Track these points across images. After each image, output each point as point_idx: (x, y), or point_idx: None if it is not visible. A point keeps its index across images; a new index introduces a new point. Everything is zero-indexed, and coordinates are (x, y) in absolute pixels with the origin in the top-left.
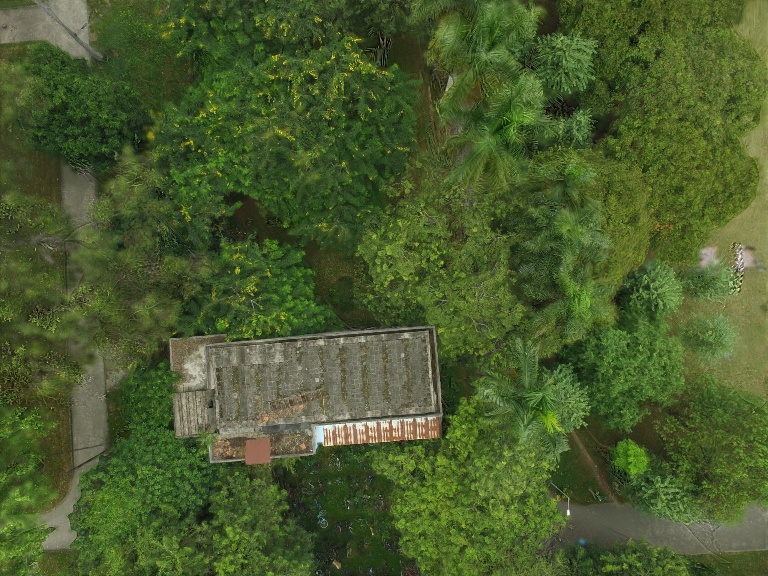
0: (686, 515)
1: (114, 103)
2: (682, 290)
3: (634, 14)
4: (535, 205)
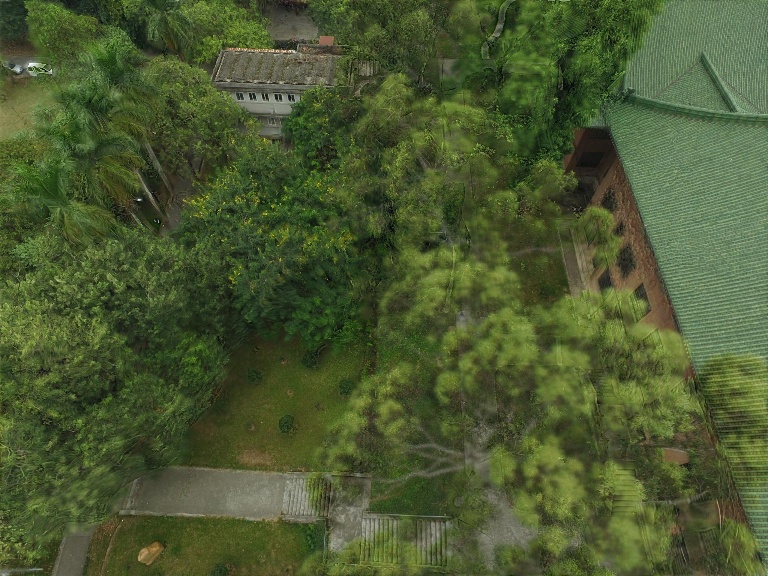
0: (112, 29)
1: None
2: None
3: None
4: None
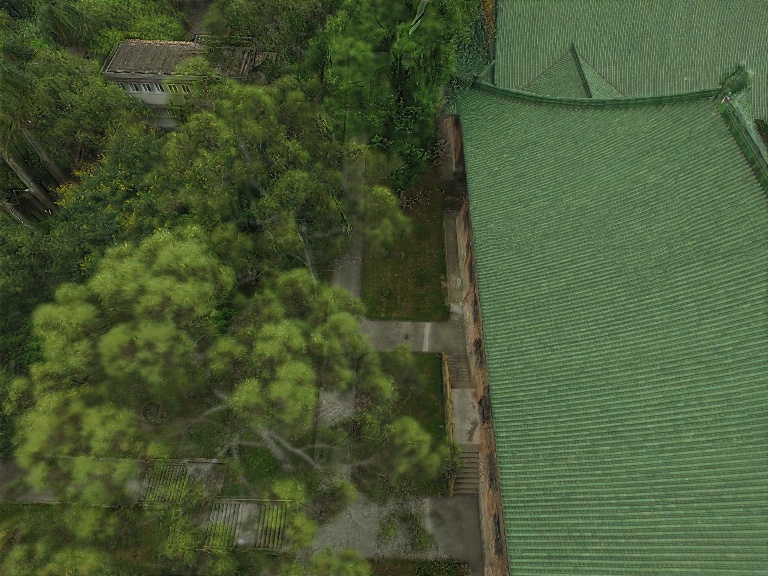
0: (20, 21)
1: None
2: None
3: None
4: None
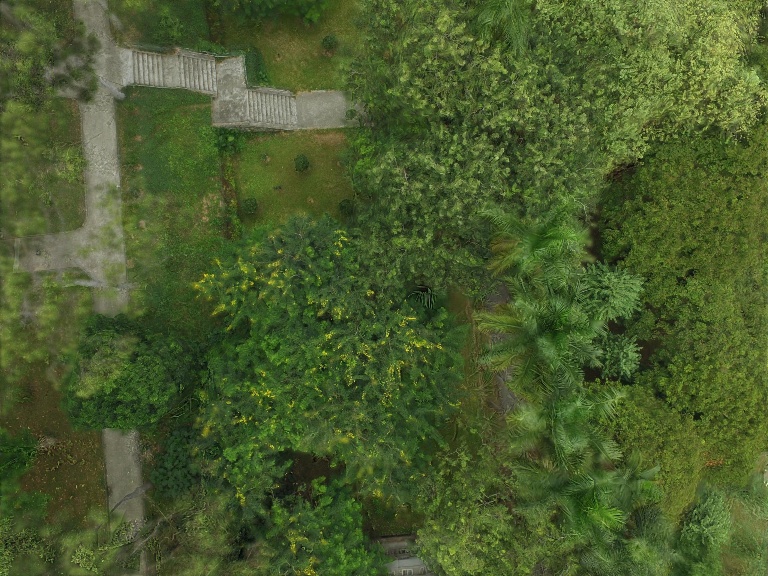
0: None
1: (163, 377)
2: (730, 516)
3: (683, 262)
4: (600, 509)
